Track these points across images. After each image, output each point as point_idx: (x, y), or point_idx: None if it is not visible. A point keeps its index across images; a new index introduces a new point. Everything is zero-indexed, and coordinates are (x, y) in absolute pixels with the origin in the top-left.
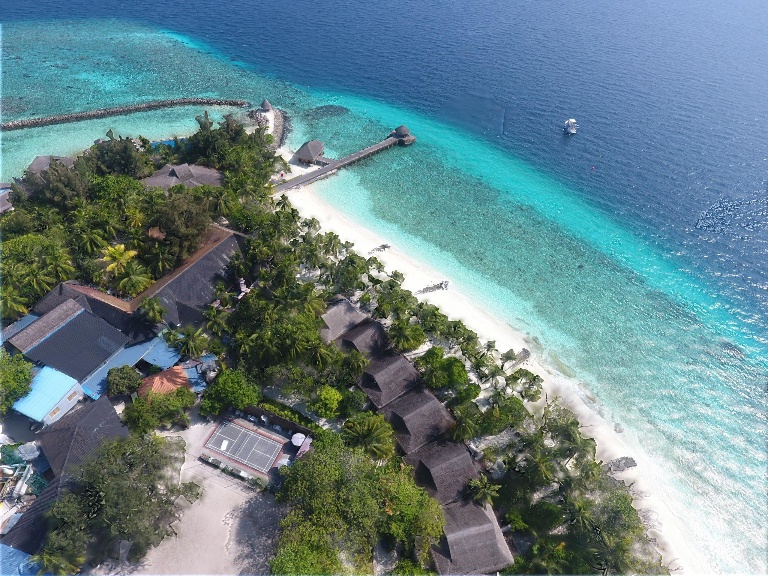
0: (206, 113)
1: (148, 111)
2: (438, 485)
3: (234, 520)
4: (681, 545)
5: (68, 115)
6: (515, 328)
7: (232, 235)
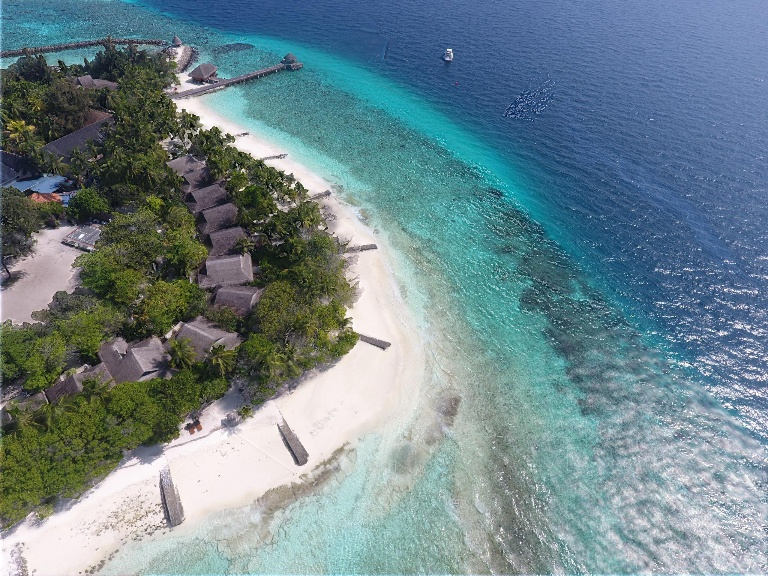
0: (108, 37)
1: (76, 49)
2: (214, 244)
3: (78, 270)
4: (386, 285)
5: (6, 51)
6: (327, 180)
7: (111, 116)
